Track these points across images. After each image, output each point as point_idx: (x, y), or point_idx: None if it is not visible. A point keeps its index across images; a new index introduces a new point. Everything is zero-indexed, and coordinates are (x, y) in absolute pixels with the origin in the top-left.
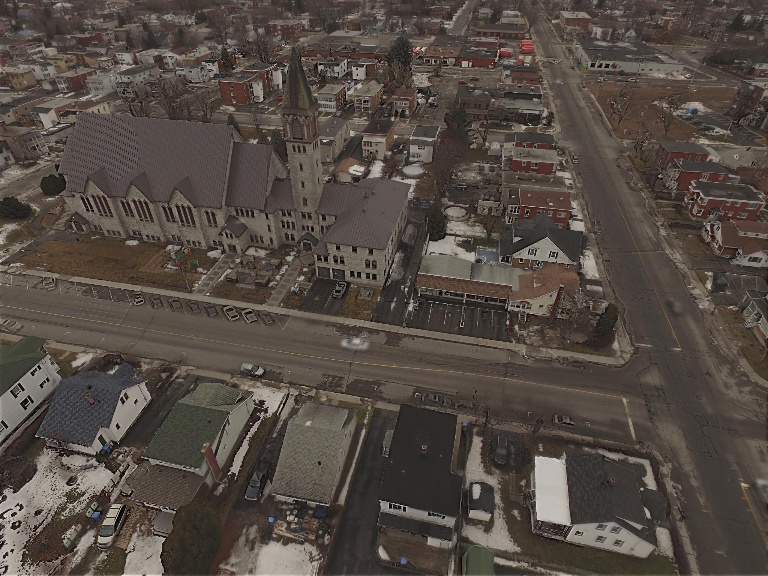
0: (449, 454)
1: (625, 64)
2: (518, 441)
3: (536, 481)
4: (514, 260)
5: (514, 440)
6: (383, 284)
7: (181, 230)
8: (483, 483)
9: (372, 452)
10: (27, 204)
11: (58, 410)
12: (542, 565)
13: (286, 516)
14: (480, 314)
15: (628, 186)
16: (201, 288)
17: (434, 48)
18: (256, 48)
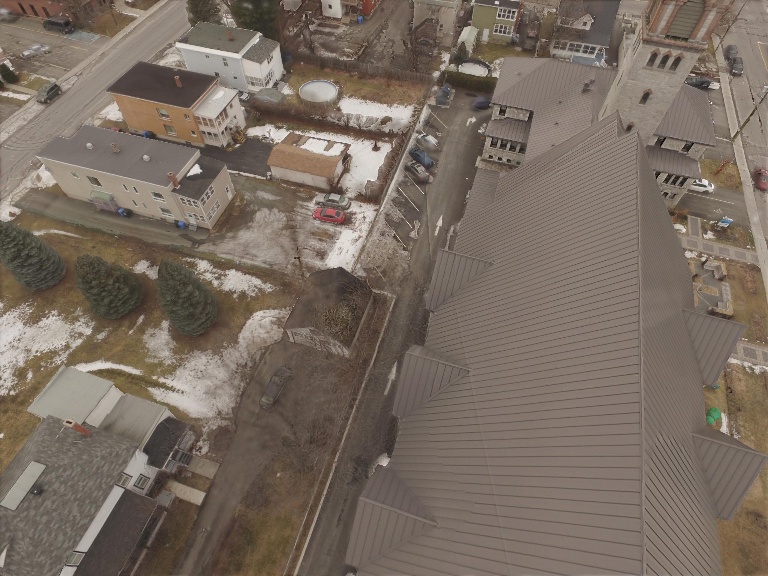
0: None
1: None
2: None
3: None
4: None
5: None
6: None
7: None
8: None
9: None
10: None
11: None
12: None
13: None
14: None
15: None
16: (762, 358)
17: None
18: None
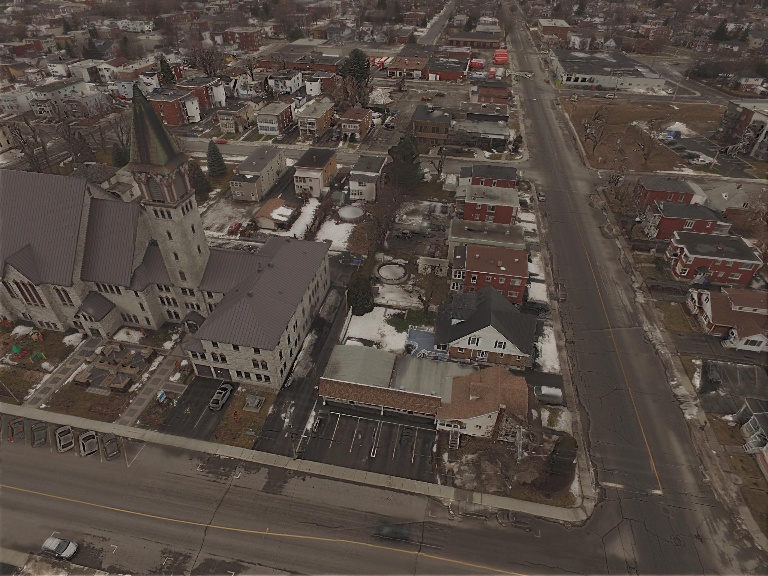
0: None
1: (603, 78)
2: None
3: None
4: (452, 349)
5: None
6: (280, 386)
7: (28, 309)
8: None
9: None
10: None
11: None
12: None
13: None
14: (400, 434)
15: (601, 232)
16: (37, 396)
17: (400, 59)
18: (200, 60)
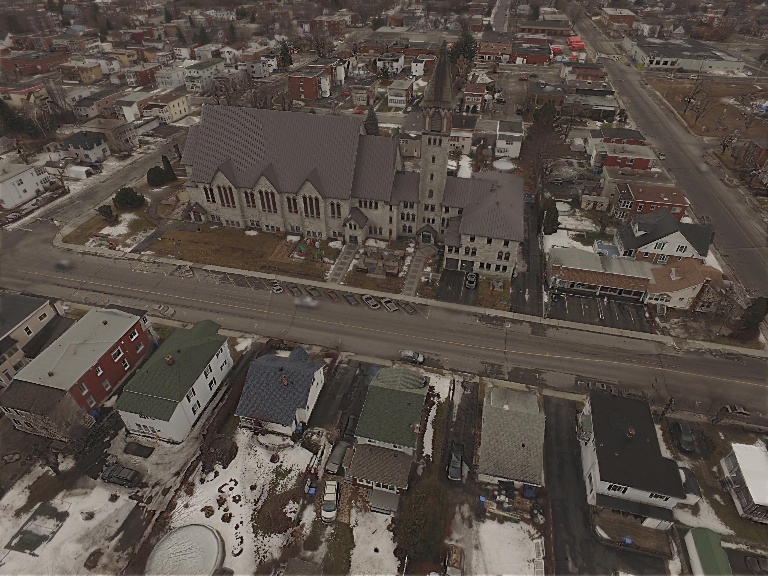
0: (654, 439)
1: (684, 61)
2: (696, 429)
3: (741, 467)
4: (638, 254)
5: (692, 428)
6: (511, 276)
7: (303, 221)
8: (685, 468)
9: (555, 437)
10: (141, 194)
11: (252, 391)
12: (762, 548)
13: (494, 496)
14: (617, 306)
15: (723, 183)
16: (334, 277)
17: None
18: (315, 44)
